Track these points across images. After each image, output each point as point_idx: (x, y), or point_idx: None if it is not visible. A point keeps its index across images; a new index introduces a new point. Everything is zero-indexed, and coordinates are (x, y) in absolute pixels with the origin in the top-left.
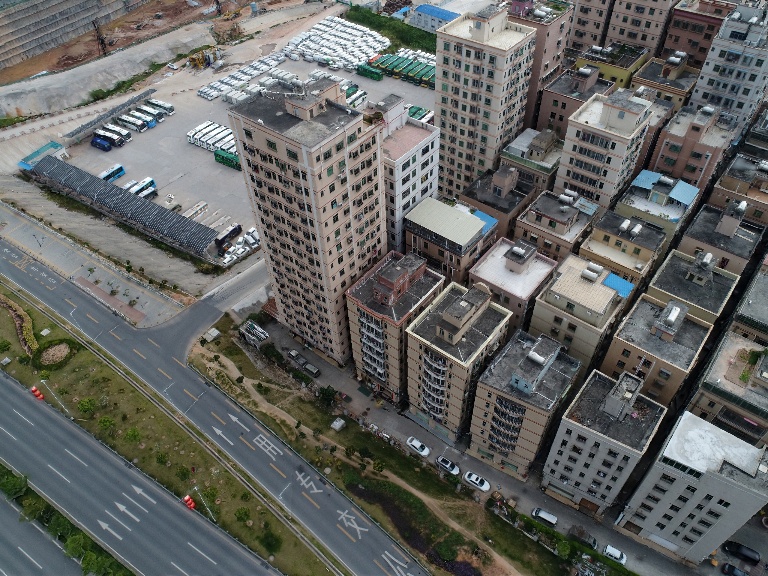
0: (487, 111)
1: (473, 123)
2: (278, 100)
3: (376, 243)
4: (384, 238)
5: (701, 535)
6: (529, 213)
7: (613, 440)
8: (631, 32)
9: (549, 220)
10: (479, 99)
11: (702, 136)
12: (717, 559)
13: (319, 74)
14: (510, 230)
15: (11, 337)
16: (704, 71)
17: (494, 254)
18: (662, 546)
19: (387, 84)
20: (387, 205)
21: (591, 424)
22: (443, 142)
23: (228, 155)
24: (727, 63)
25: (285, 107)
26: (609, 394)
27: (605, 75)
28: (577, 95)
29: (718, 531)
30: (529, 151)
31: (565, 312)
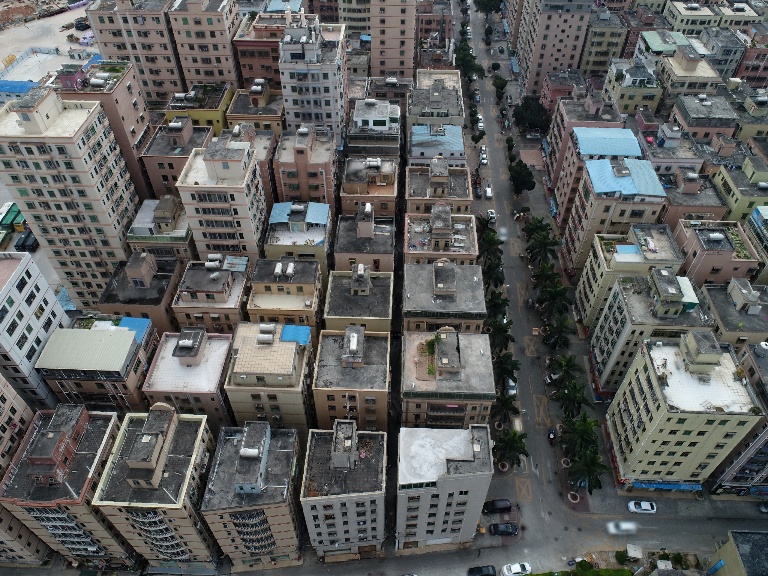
0: (86, 203)
1: (78, 219)
2: None
3: (10, 415)
4: (19, 403)
5: (462, 522)
6: (181, 295)
7: (354, 495)
8: (206, 70)
9: (205, 294)
10: (70, 193)
11: (309, 156)
12: (483, 525)
13: None
14: (172, 317)
15: None
16: (285, 94)
17: (163, 355)
18: (440, 544)
19: None
20: (3, 365)
21: (329, 489)
22: (55, 248)
23: None
24: (300, 83)
25: None
26: (331, 452)
27: (200, 120)
28: (179, 151)
29: (471, 512)
30: (156, 225)
31: (258, 387)
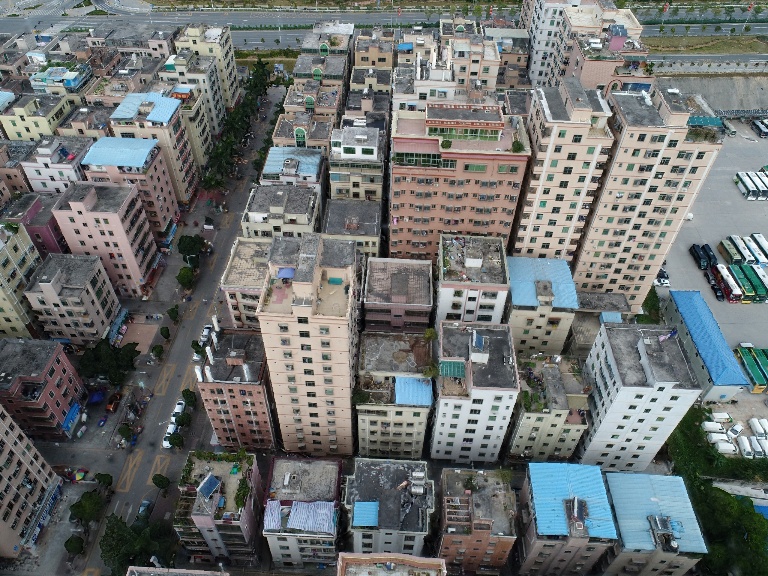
0: None
1: None
2: None
3: None
4: None
5: None
6: None
7: None
8: None
9: None
10: None
11: None
12: None
13: None
14: None
15: (644, 42)
16: None
17: None
18: None
19: None
20: None
21: (384, 34)
22: None
23: None
24: None
25: None
26: None
27: None
28: None
29: None
30: None
31: None
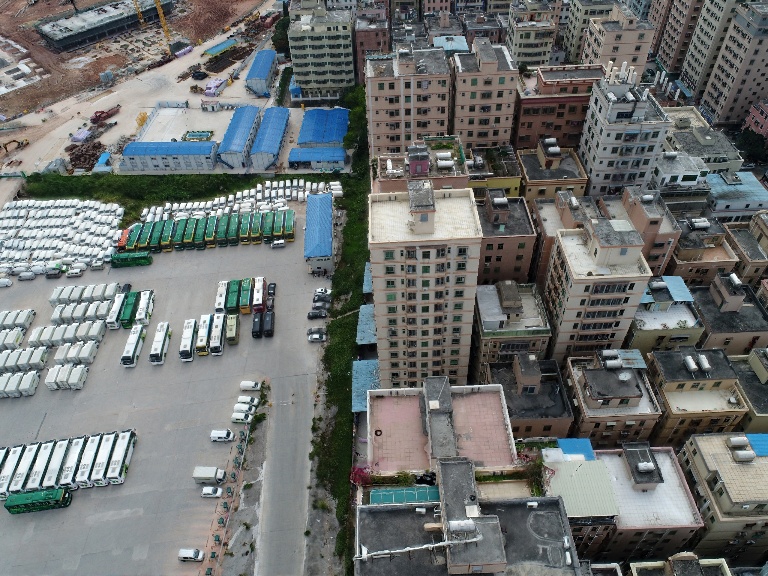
0: (459, 303)
1: (440, 320)
2: (402, 554)
3: None
4: None
5: None
6: (593, 403)
7: None
8: (482, 132)
9: (620, 400)
10: (445, 294)
11: None
12: None
13: (65, 294)
14: None
15: None
16: (602, 156)
17: None
18: None
19: (164, 264)
20: None
21: None
22: (394, 350)
23: (34, 498)
24: (625, 143)
25: (432, 563)
26: None
27: None
28: (505, 228)
29: None
30: (506, 316)
31: (760, 517)
